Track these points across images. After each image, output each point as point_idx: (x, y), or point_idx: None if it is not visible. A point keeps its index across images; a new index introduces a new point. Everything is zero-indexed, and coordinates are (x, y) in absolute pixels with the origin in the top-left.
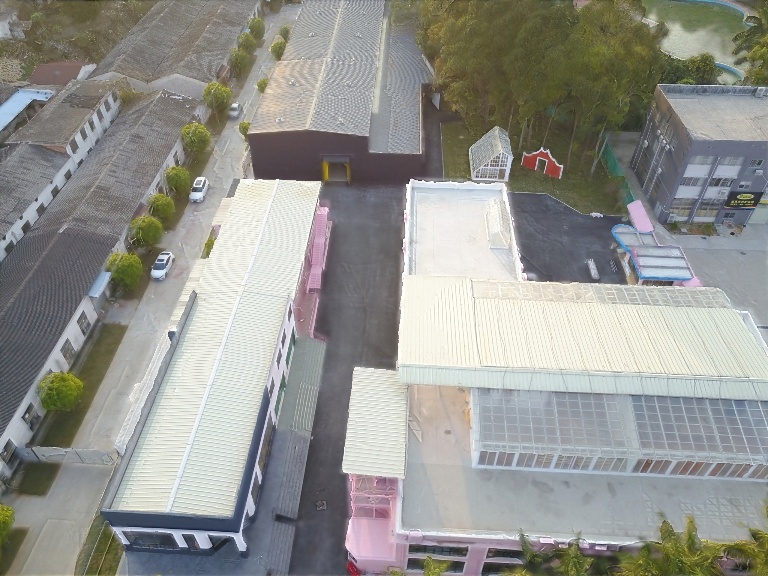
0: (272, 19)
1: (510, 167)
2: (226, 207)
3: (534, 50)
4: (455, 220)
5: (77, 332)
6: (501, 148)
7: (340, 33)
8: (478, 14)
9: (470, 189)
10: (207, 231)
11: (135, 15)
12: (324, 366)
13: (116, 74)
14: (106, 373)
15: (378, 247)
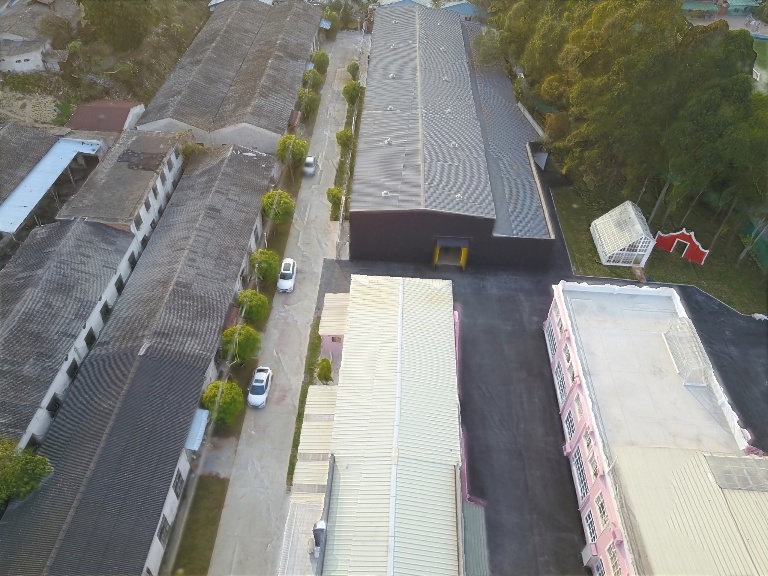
0: (329, 48)
1: (650, 252)
2: (332, 308)
3: (708, 126)
4: (628, 341)
5: (172, 500)
6: (643, 231)
7: (425, 75)
8: (627, 75)
9: (632, 294)
10: (305, 334)
11: (177, 40)
12: (488, 543)
13: (173, 121)
14: (211, 557)
15: (517, 360)
